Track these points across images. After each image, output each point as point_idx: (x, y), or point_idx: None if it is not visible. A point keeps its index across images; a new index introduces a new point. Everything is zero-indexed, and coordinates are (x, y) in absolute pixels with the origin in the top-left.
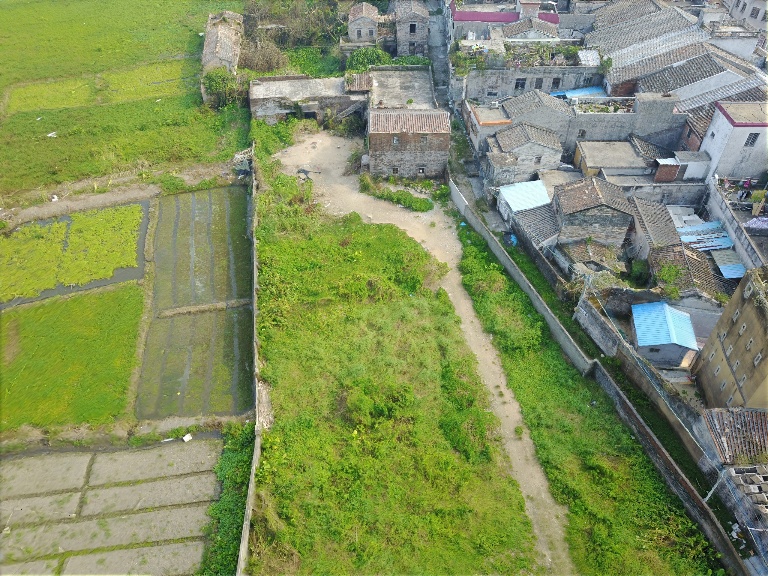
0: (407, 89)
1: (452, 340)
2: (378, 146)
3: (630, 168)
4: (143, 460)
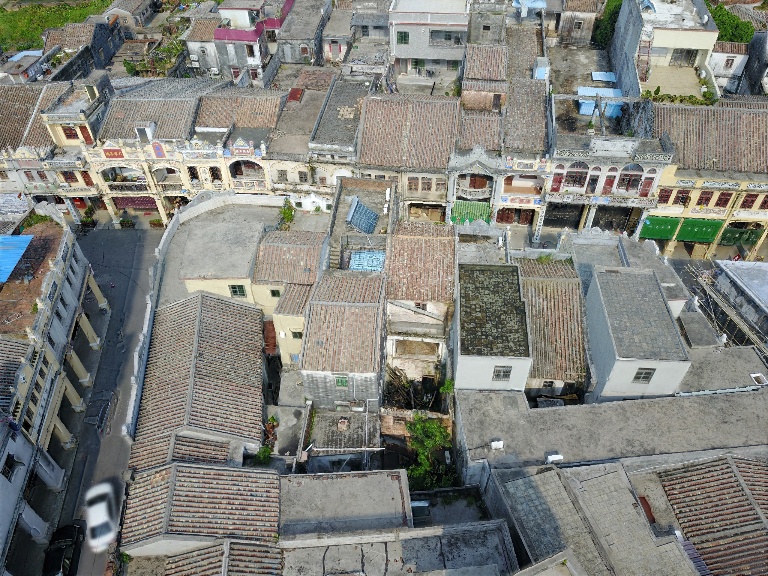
0: None
1: None
2: None
3: None
4: None
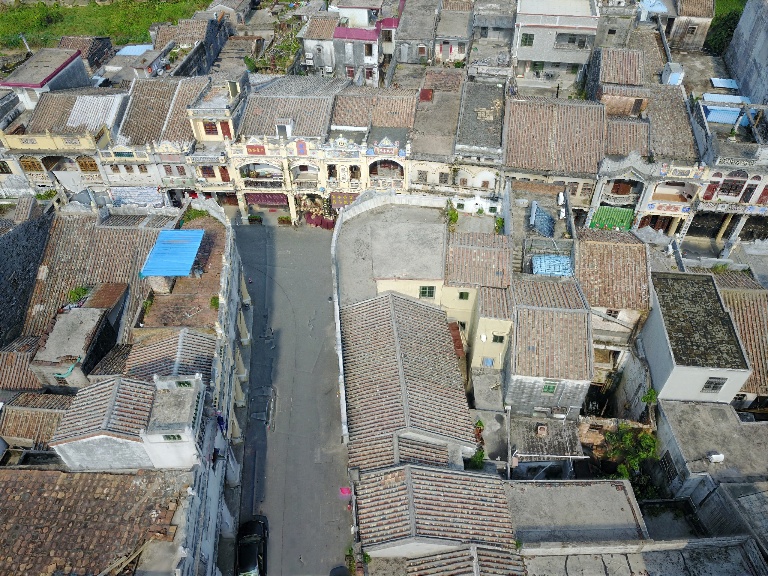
0: None
1: None
2: None
3: None
4: None
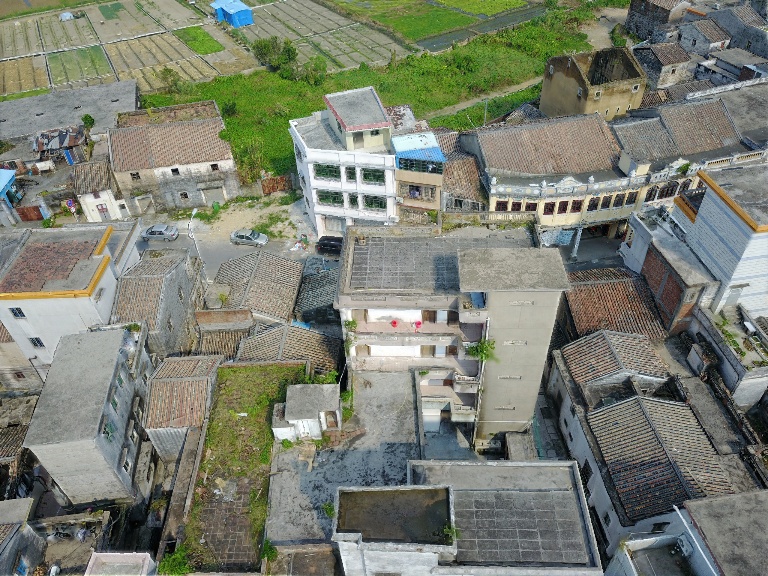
0: (728, 5)
1: (520, 72)
2: (634, 7)
3: (733, 66)
4: (401, 49)
